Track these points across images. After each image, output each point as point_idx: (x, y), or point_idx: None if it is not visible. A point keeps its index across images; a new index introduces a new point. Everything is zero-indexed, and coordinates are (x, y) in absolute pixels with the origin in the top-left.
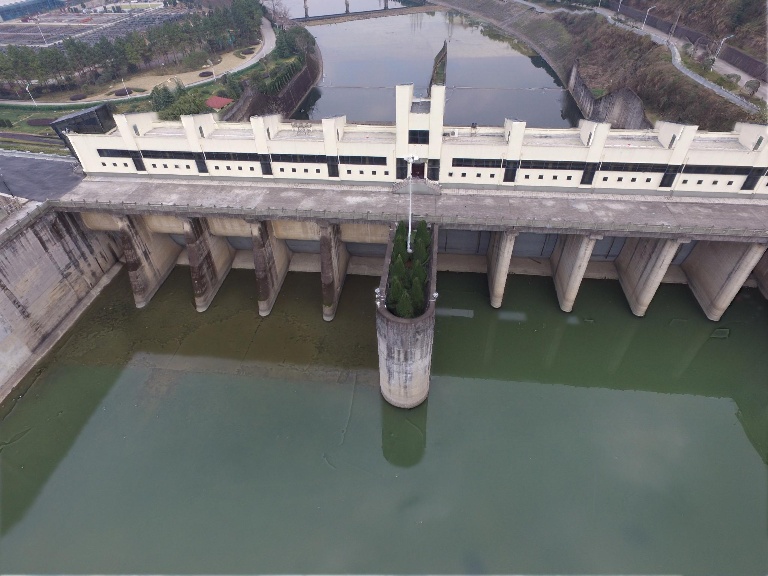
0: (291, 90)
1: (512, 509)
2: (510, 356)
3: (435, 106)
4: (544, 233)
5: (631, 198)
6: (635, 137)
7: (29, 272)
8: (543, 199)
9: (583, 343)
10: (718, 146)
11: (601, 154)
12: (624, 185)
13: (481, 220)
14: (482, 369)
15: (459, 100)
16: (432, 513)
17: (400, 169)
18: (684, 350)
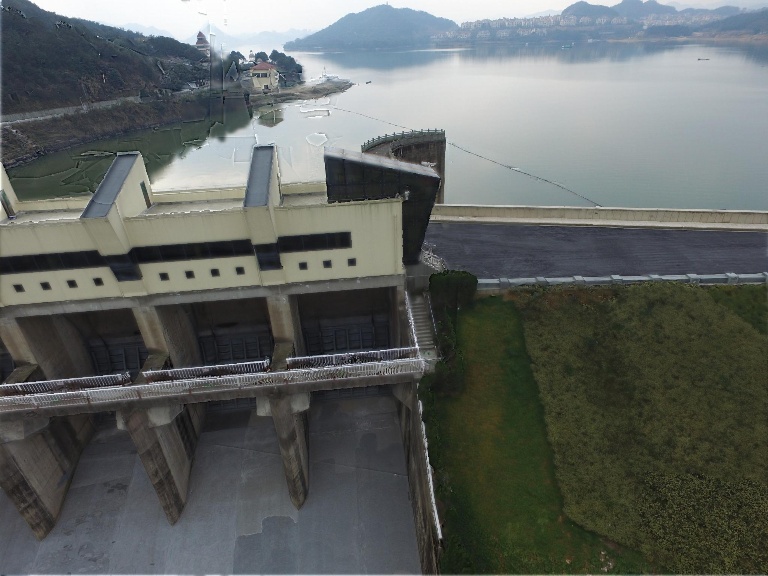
0: None
1: None
2: None
3: None
4: None
5: None
6: None
7: None
8: None
9: None
10: None
11: None
12: None
13: None
14: None
15: None
16: None
17: None
18: None
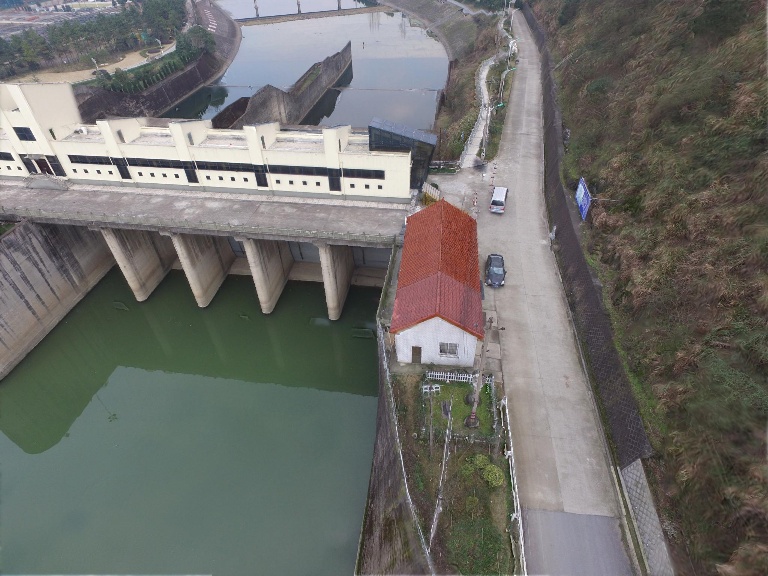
0: (165, 88)
1: None
2: (187, 350)
3: (20, 104)
4: (121, 228)
5: (234, 197)
6: (244, 137)
7: None
8: (156, 196)
9: (246, 339)
10: (309, 147)
11: (189, 153)
12: (228, 184)
13: (62, 215)
14: (167, 362)
15: (344, 100)
16: None
17: (29, 165)
18: (333, 349)
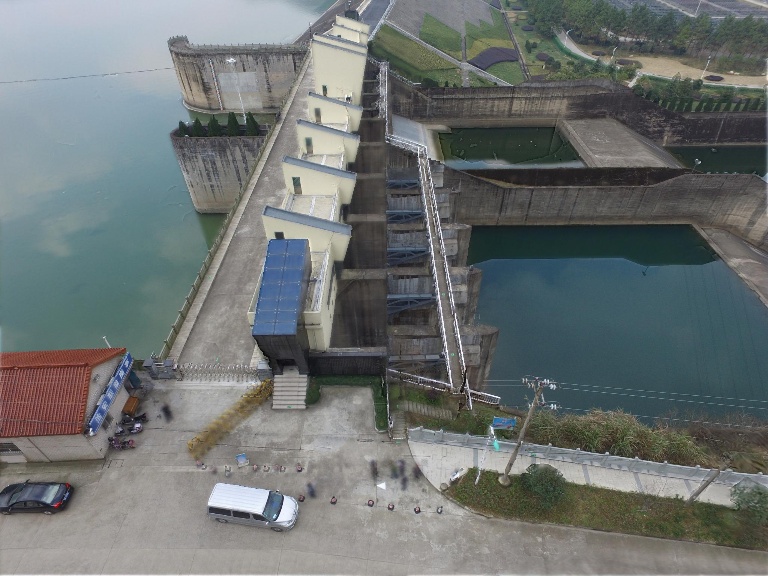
0: (726, 122)
1: (119, 246)
2: None
3: None
4: None
5: None
6: None
7: (281, 74)
8: None
9: None
10: None
11: None
12: None
13: None
14: None
15: None
16: (129, 218)
17: None
18: None
